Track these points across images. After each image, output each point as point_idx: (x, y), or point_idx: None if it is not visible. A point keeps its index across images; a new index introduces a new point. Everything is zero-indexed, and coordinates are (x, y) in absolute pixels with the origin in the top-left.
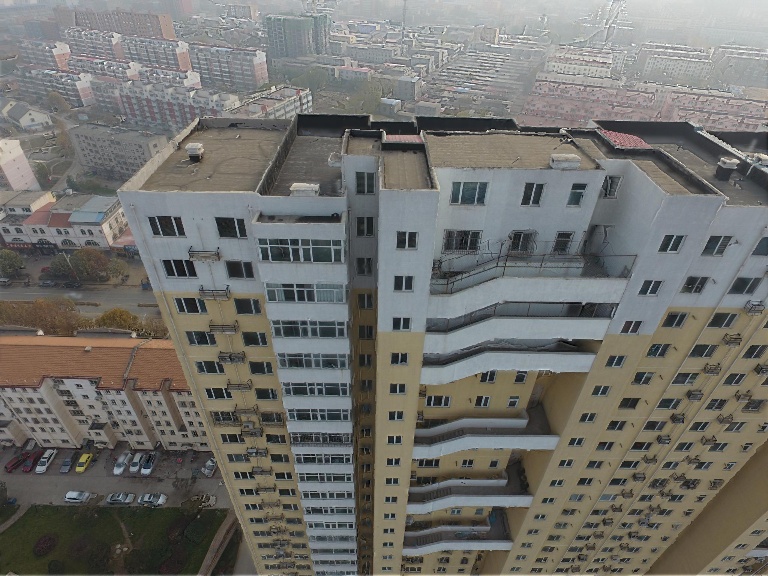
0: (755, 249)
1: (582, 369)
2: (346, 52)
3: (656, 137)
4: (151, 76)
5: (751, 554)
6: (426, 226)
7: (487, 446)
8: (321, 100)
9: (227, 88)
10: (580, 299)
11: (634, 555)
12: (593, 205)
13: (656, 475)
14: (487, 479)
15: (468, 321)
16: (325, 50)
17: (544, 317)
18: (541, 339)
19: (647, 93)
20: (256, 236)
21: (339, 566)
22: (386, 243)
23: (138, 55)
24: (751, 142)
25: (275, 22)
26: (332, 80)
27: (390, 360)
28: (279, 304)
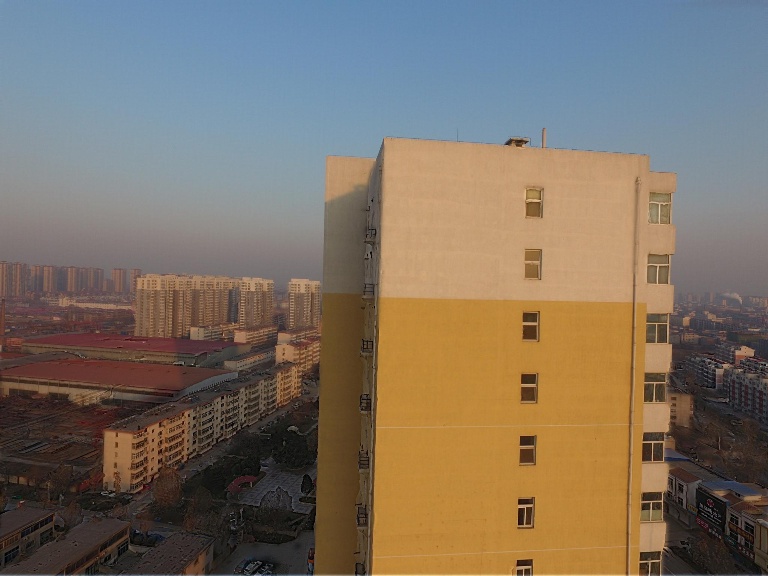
0: None
1: None
2: None
3: None
4: None
5: None
6: None
7: None
8: None
9: None
10: None
11: None
12: None
13: None
14: None
15: None
16: None
17: None
18: None
19: None
20: None
21: None
22: None
23: None
24: None
25: None
26: None
27: None
28: None
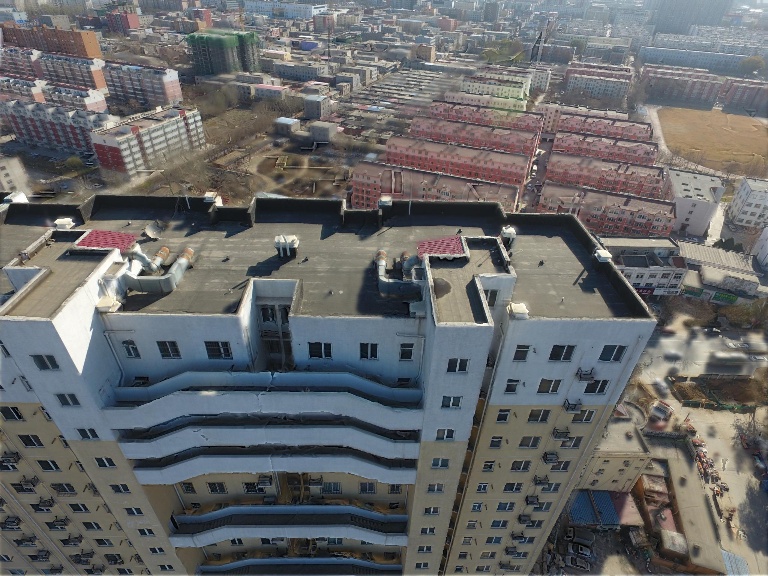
0: None
1: None
2: (275, 69)
3: None
4: (53, 94)
5: None
6: None
7: None
8: (210, 120)
9: (132, 106)
10: None
11: None
12: None
13: (68, 551)
14: None
15: None
16: (254, 67)
17: None
18: None
19: (536, 114)
20: None
21: None
22: None
23: (56, 72)
24: (70, 214)
25: (198, 40)
26: (247, 98)
27: None
28: None
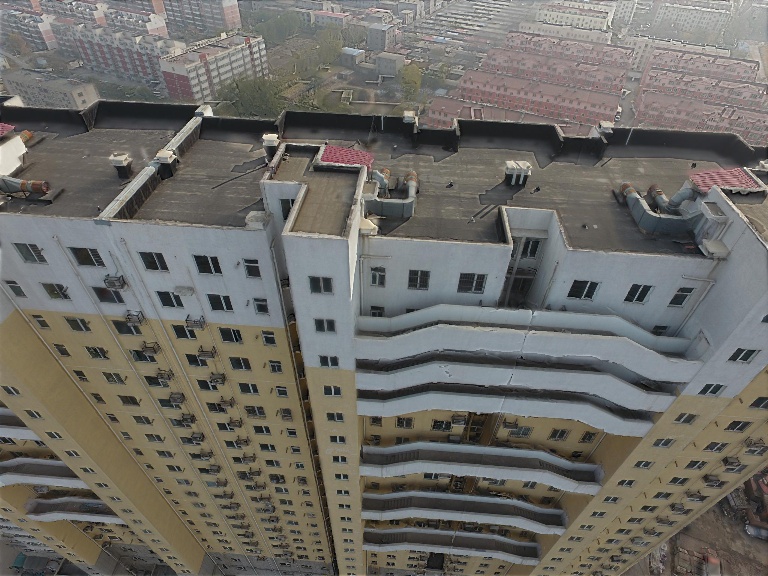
0: (83, 258)
1: None
2: None
3: (172, 121)
4: (116, 18)
5: (367, 548)
6: None
7: None
8: (275, 49)
9: (192, 33)
10: None
11: (300, 537)
12: None
13: (236, 468)
14: (55, 460)
15: None
16: None
17: None
18: None
19: (626, 49)
20: None
21: (11, 523)
22: None
23: None
24: (261, 131)
25: None
26: (306, 26)
27: None
28: None
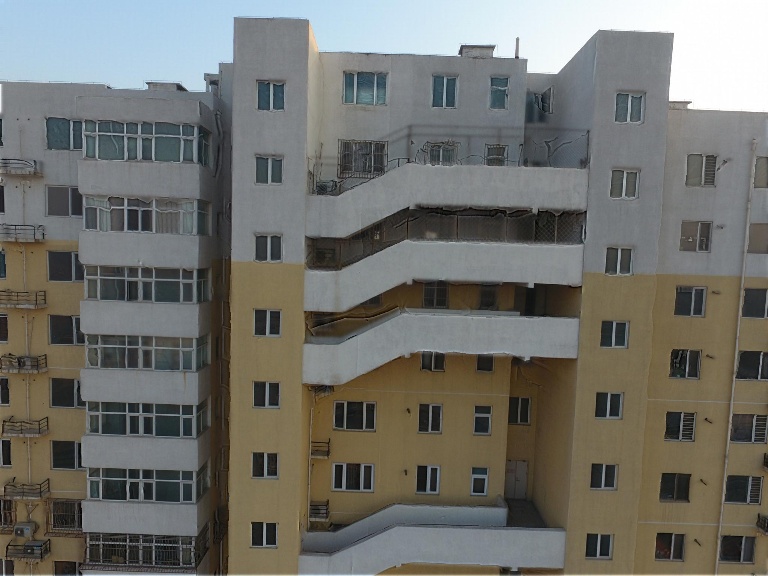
0: (755, 181)
1: (564, 351)
2: None
3: None
4: None
5: None
6: (295, 72)
7: (436, 556)
8: None
9: None
10: (527, 203)
11: None
12: (522, 107)
13: None
14: None
15: (370, 248)
16: None
17: (483, 242)
18: (486, 285)
19: None
20: (82, 116)
21: None
22: (242, 98)
23: None
24: None
25: None
26: None
27: (253, 327)
28: (99, 233)
